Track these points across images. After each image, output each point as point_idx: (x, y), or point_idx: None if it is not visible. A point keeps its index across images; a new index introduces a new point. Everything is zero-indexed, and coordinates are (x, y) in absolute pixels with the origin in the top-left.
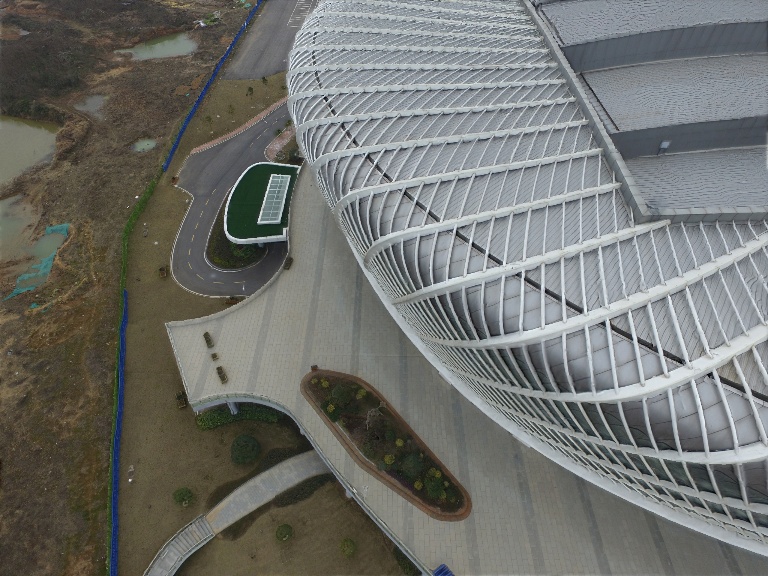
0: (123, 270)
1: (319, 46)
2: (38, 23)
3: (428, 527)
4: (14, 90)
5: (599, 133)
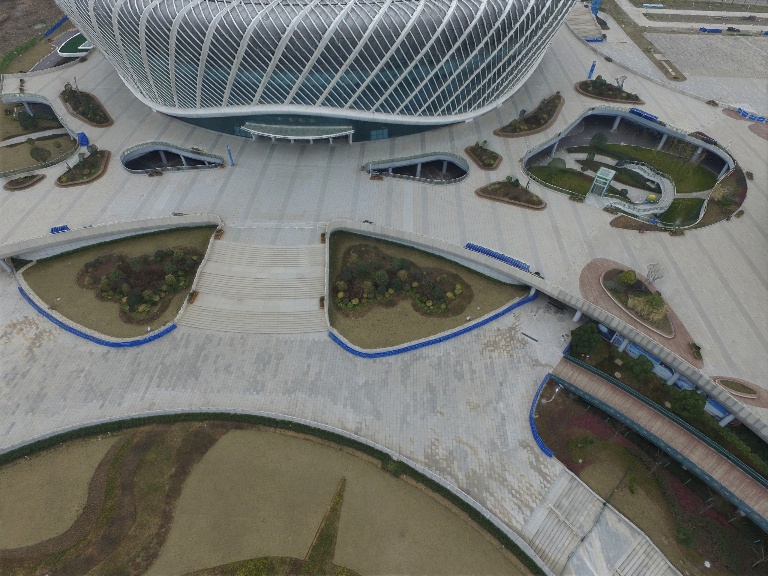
0: None
1: None
2: None
3: (88, 128)
4: None
5: None
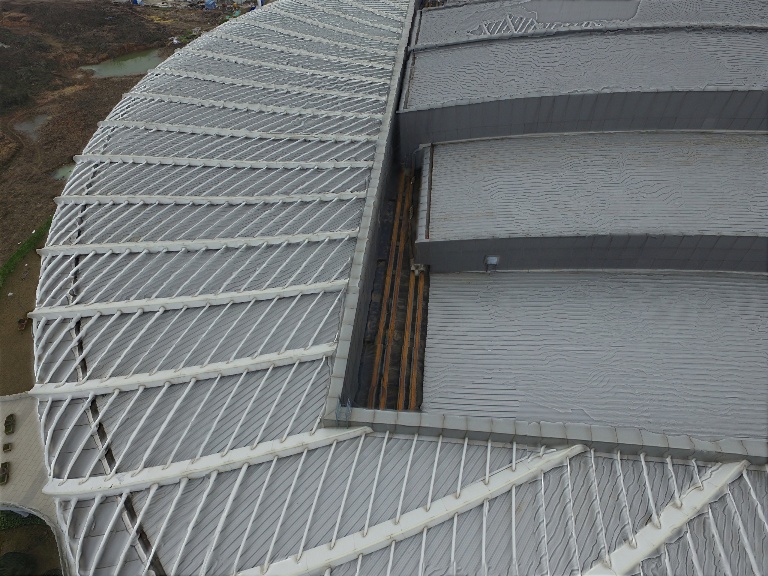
0: None
1: (139, 94)
2: (15, 36)
3: None
4: None
5: (353, 256)
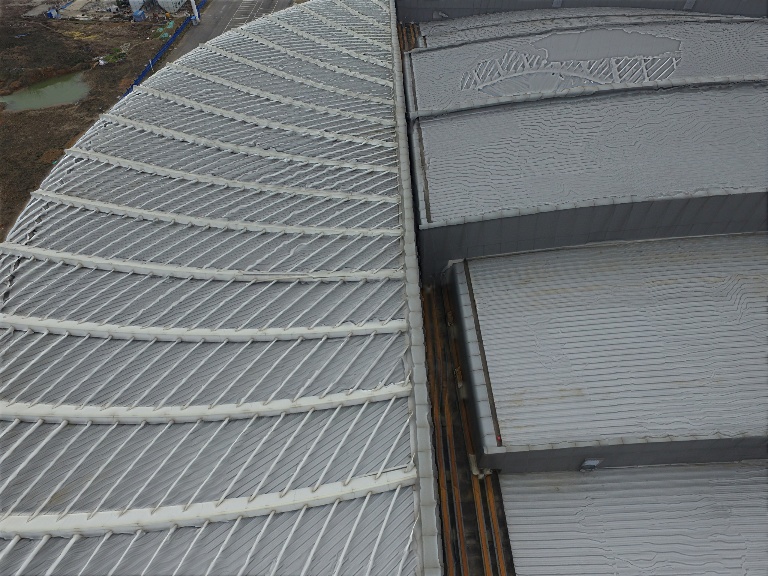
0: None
1: (53, 198)
2: None
3: None
4: None
5: None
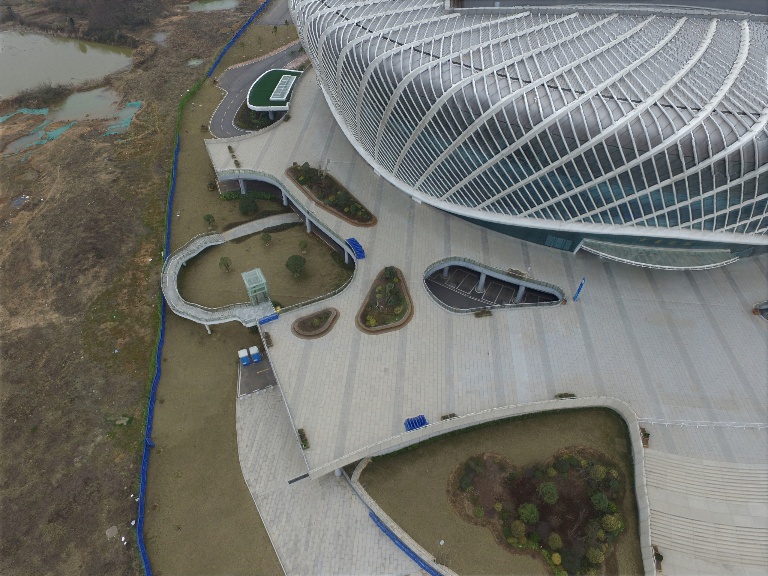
0: (177, 124)
1: None
2: None
3: (349, 228)
4: (104, 24)
5: None
